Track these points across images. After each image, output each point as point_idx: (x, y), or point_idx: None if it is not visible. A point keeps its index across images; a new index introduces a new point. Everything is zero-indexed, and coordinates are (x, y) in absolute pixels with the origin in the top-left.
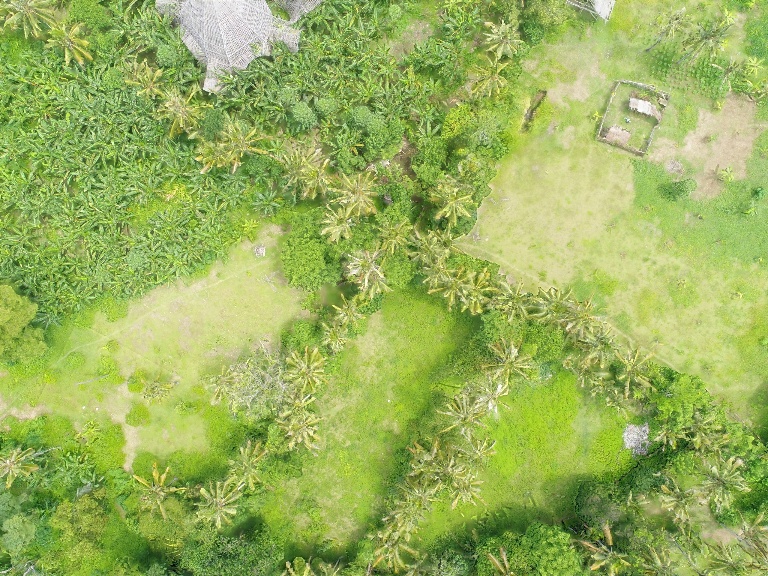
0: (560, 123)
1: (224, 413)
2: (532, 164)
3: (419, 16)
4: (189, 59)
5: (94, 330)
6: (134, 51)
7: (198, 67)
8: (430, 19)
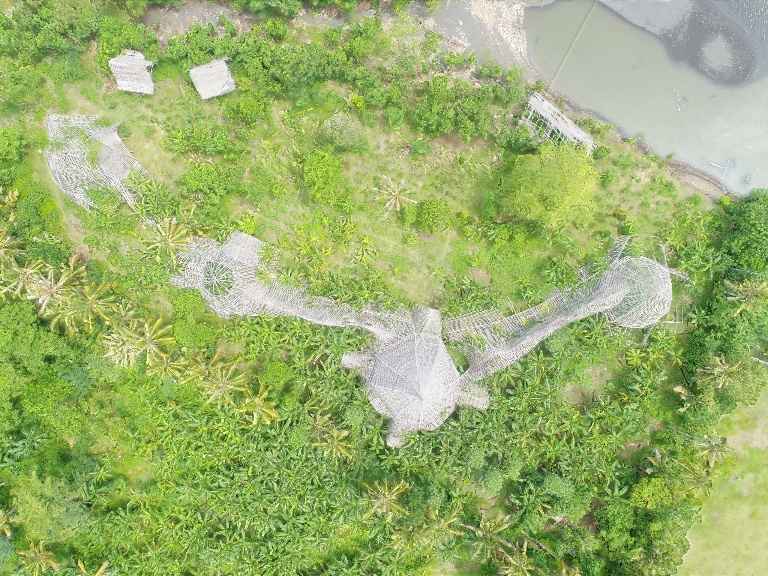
0: (740, 472)
1: None
2: (711, 510)
3: (598, 361)
4: (371, 411)
5: None
6: (316, 403)
7: (380, 418)
8: (609, 364)
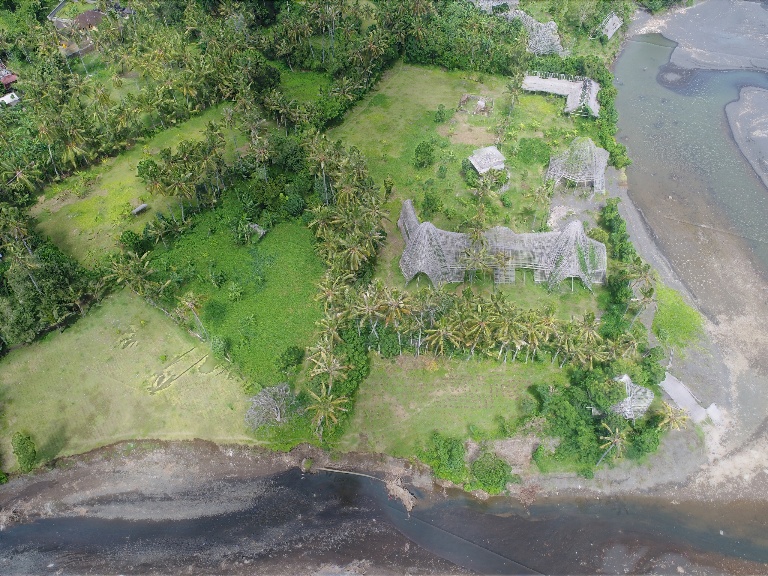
0: (467, 86)
1: None
2: None
3: None
4: None
5: None
6: None
7: None
8: None
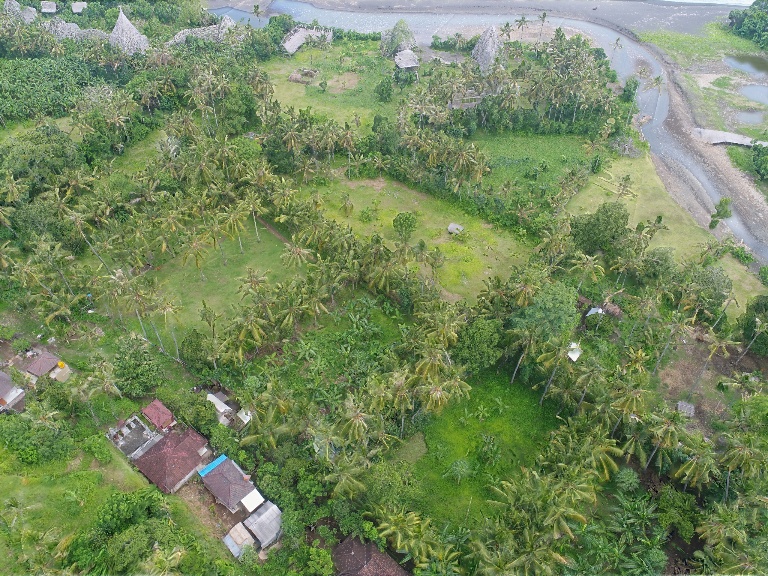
0: None
1: None
2: None
3: None
4: None
5: (14, 131)
6: None
7: None
8: None
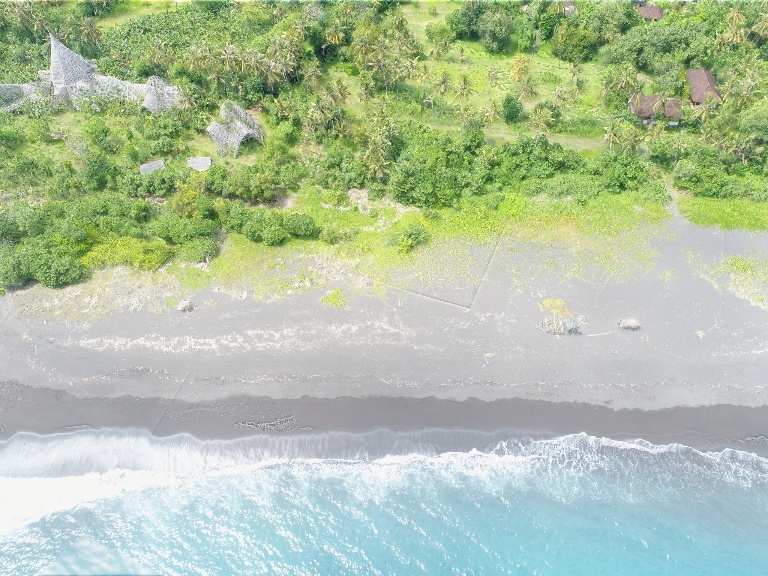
0: None
1: (130, 4)
2: None
3: None
4: None
5: None
6: None
7: None
8: None
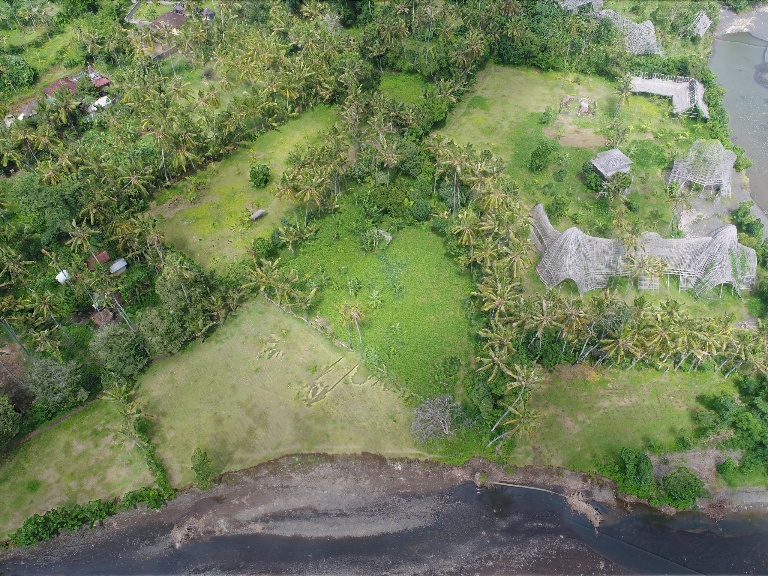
0: (565, 87)
1: None
2: None
3: None
4: None
5: None
6: None
7: None
8: None
